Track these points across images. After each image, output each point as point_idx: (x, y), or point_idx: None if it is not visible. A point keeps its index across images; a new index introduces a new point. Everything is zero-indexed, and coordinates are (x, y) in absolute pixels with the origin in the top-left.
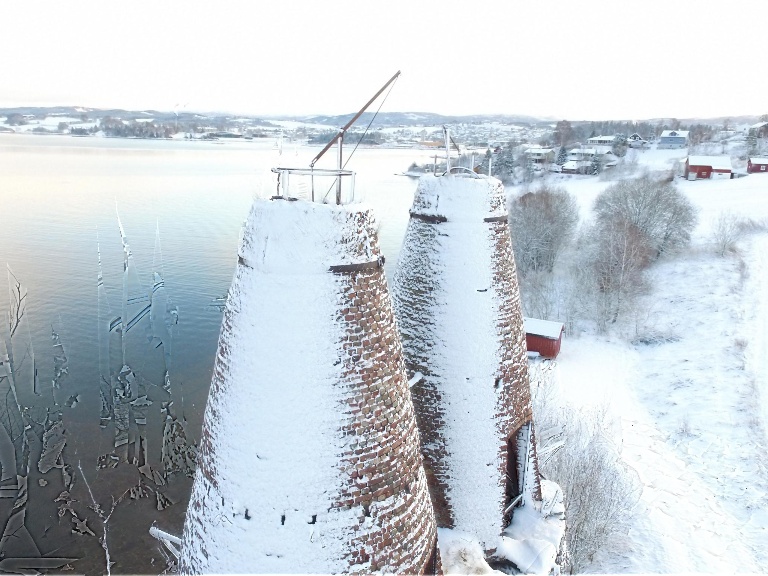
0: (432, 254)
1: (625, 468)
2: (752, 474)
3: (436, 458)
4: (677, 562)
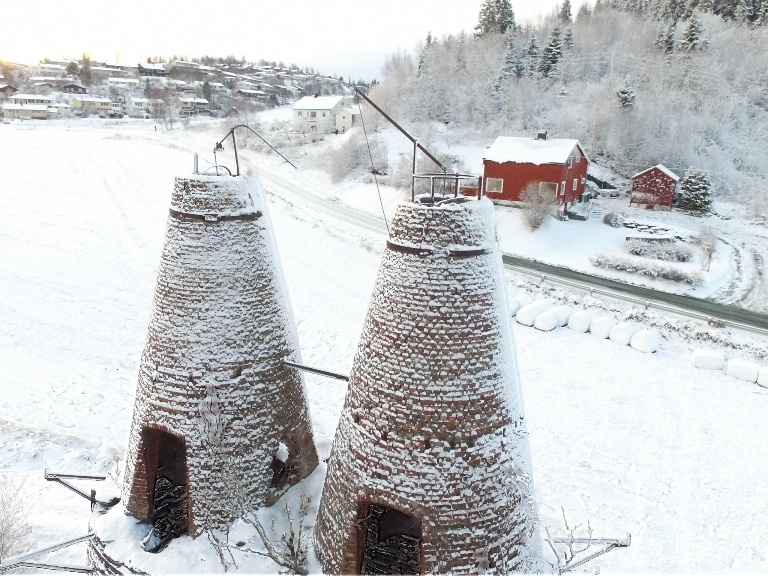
0: (262, 249)
1: (3, 476)
2: (1, 435)
3: (306, 418)
4: (64, 523)
